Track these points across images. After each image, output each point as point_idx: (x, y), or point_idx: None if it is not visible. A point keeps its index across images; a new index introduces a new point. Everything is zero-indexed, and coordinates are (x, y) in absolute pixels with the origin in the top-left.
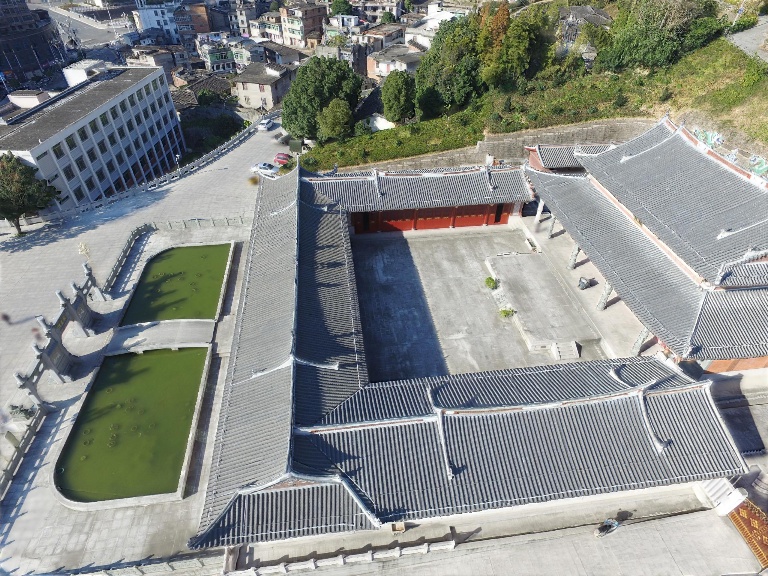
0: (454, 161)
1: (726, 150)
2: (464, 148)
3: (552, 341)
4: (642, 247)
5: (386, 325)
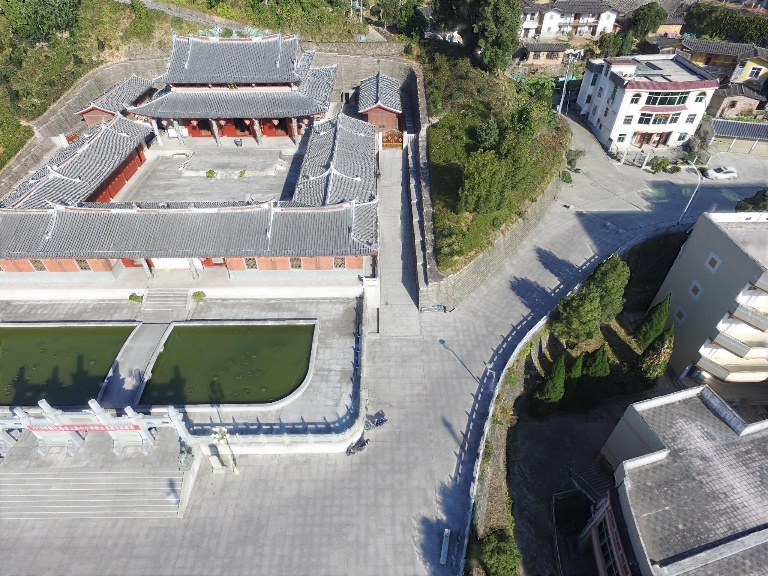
0: (36, 156)
1: None
2: (27, 143)
3: (275, 164)
4: (251, 97)
5: None
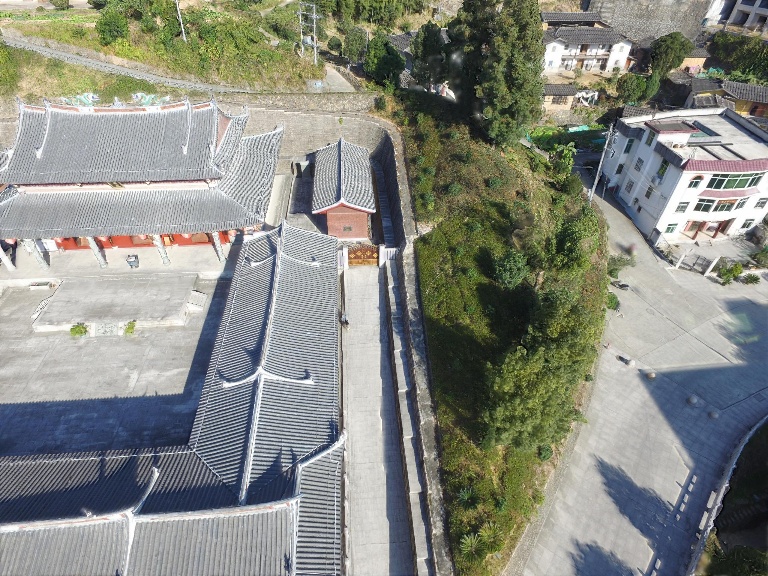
0: None
1: None
2: None
3: (184, 304)
4: (146, 199)
5: None
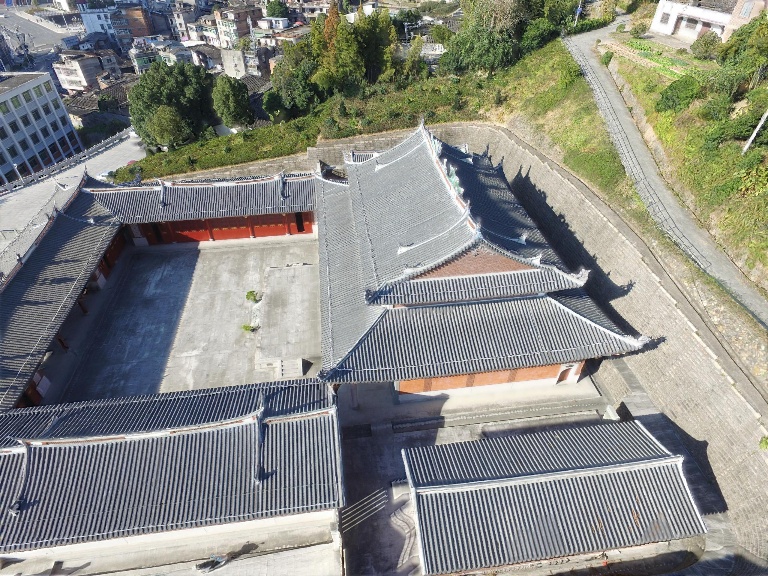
0: (284, 168)
1: (531, 155)
2: (296, 154)
3: (277, 359)
4: None
5: (124, 342)
